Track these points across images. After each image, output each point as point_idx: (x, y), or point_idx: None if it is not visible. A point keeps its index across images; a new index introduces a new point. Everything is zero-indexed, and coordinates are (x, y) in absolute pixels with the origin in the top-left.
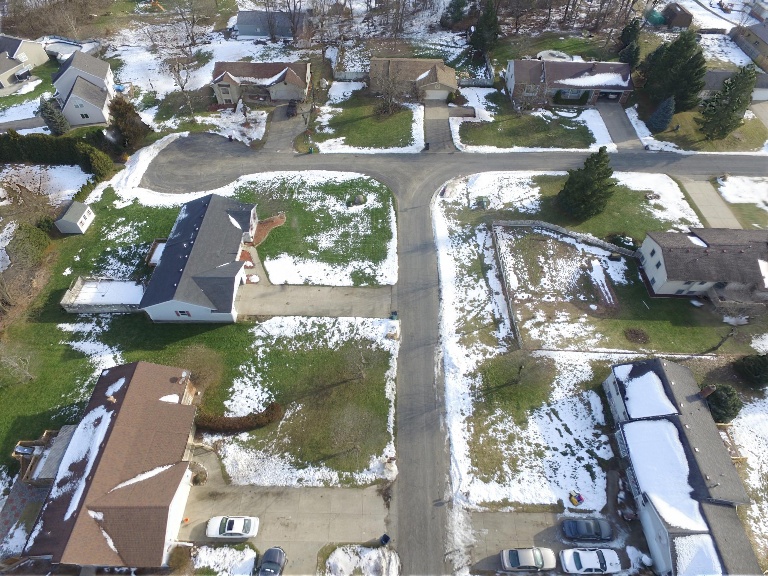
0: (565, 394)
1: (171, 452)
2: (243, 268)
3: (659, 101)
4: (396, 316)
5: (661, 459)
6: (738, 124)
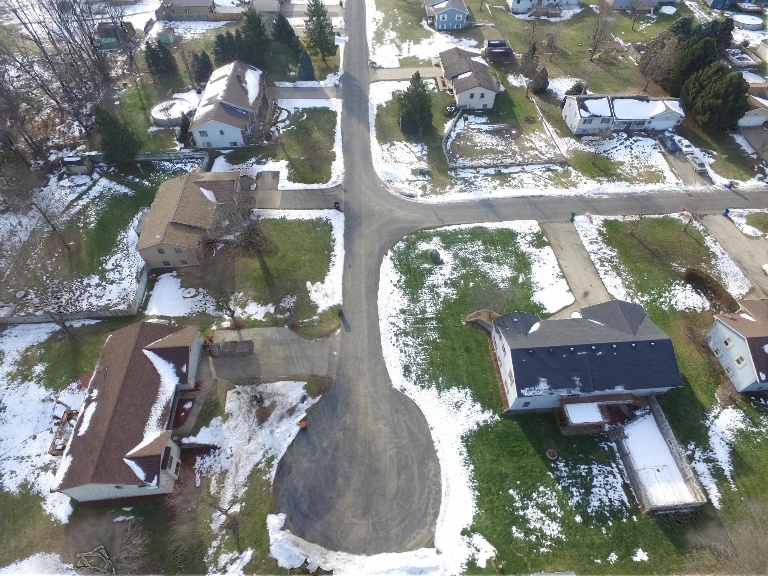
0: (590, 147)
1: None
2: None
3: (287, 63)
4: None
5: (633, 108)
6: (333, 37)
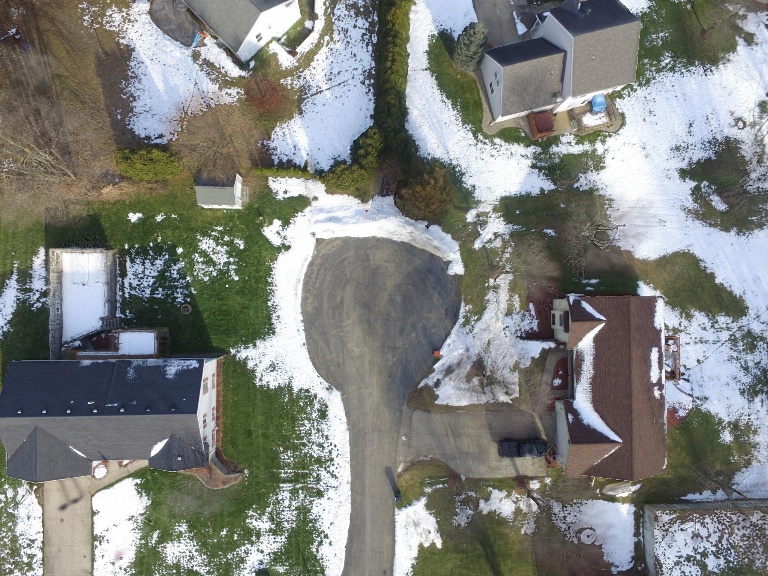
0: None
1: None
2: None
3: None
4: None
5: None
6: None
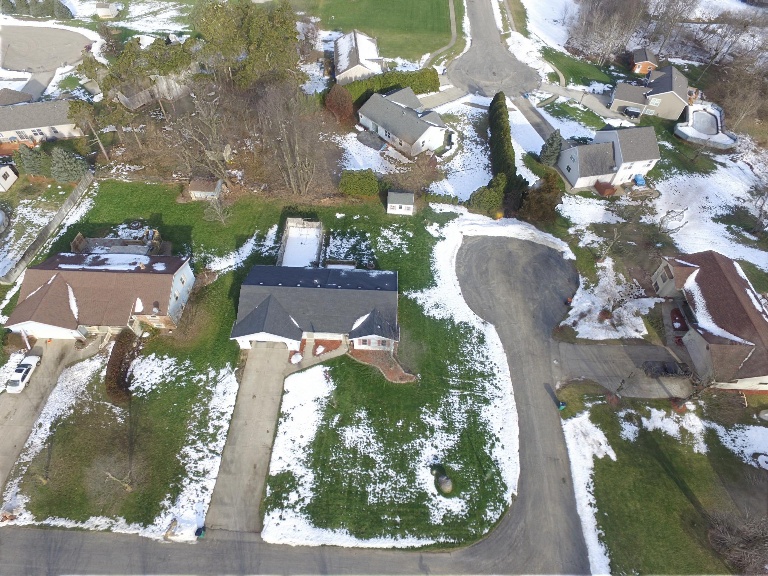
0: None
1: (88, 316)
2: (293, 341)
3: None
4: (200, 535)
5: None
6: None
